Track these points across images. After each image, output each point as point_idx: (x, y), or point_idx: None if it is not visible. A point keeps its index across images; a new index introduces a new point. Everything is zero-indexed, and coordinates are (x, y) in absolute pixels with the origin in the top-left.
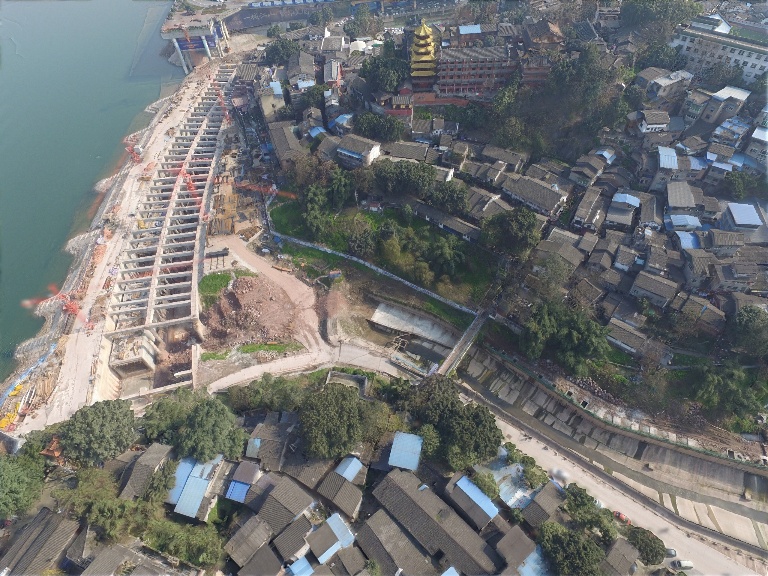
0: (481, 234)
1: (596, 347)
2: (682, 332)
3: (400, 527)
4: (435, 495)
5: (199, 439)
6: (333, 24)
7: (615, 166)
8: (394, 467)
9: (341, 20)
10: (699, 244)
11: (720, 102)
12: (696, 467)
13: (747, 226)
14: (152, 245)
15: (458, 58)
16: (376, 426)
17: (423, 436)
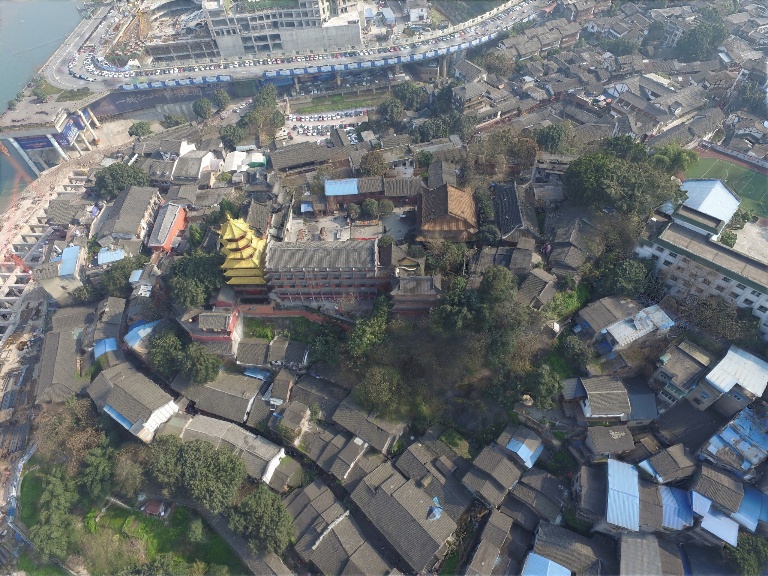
0: None
1: None
2: None
3: None
4: None
5: None
6: (230, 109)
7: (540, 469)
8: None
9: (242, 103)
10: None
11: (718, 392)
12: None
13: None
14: None
15: (294, 266)
16: None
17: None
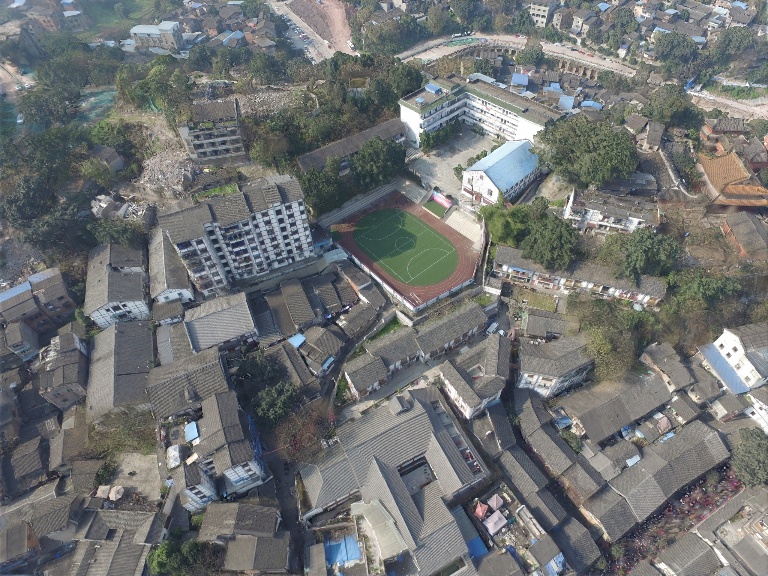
0: None
1: None
2: None
3: None
4: None
5: None
6: None
7: None
8: None
9: None
10: None
11: None
12: None
13: None
14: None
15: None
16: None
17: None
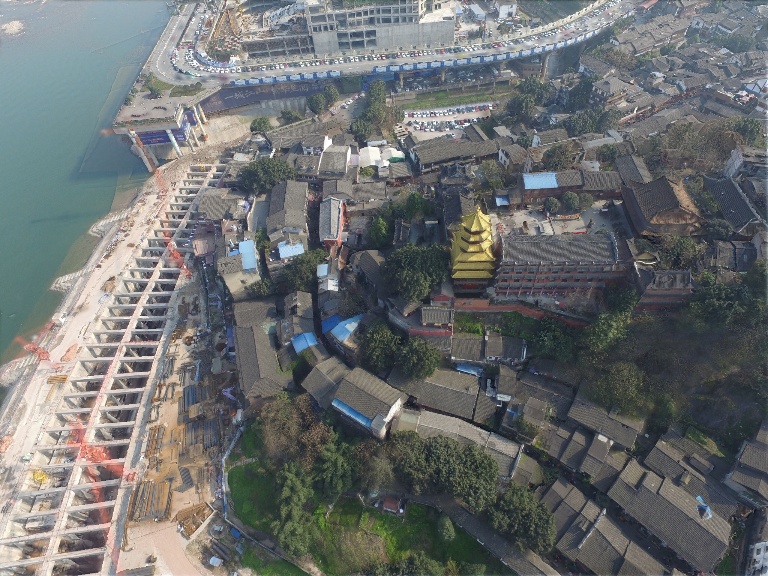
0: None
1: None
2: None
3: None
4: None
5: None
6: (338, 105)
7: None
8: None
9: (349, 99)
10: None
11: None
12: None
13: None
14: (50, 516)
15: (531, 260)
16: None
17: None
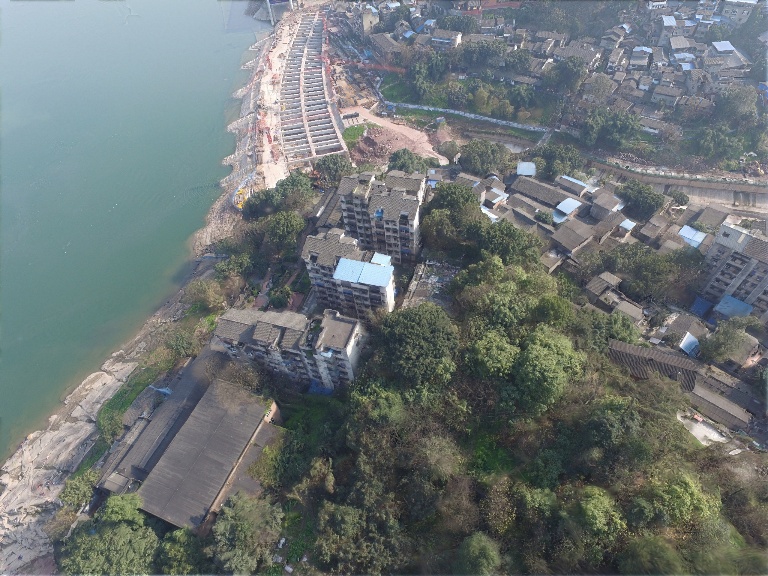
0: (544, 79)
1: (633, 126)
2: (688, 117)
3: (531, 199)
4: (549, 185)
5: (404, 161)
6: None
7: (632, 35)
8: (521, 175)
9: None
10: (695, 66)
11: None
12: (703, 193)
13: (725, 52)
14: None
15: None
16: (503, 163)
17: (535, 161)
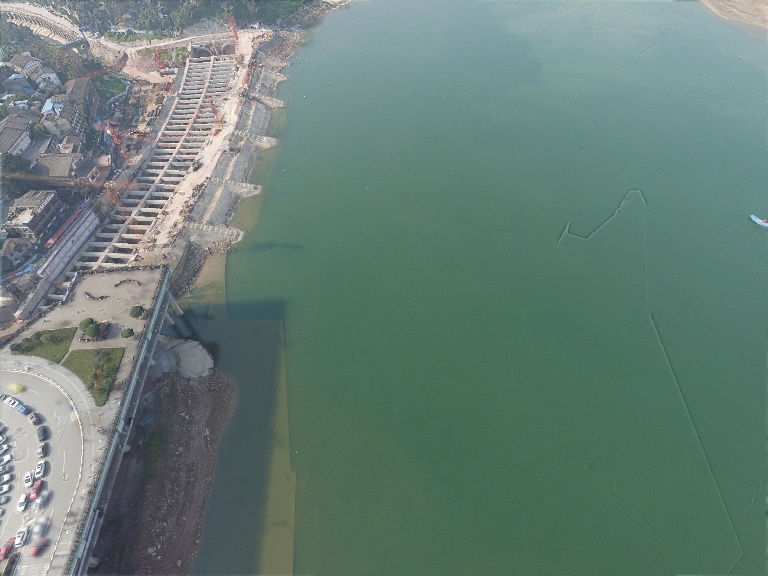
0: None
1: None
2: None
3: None
4: None
5: None
6: None
7: None
8: None
9: None
10: None
11: None
12: None
13: None
14: None
15: None
16: None
17: None
